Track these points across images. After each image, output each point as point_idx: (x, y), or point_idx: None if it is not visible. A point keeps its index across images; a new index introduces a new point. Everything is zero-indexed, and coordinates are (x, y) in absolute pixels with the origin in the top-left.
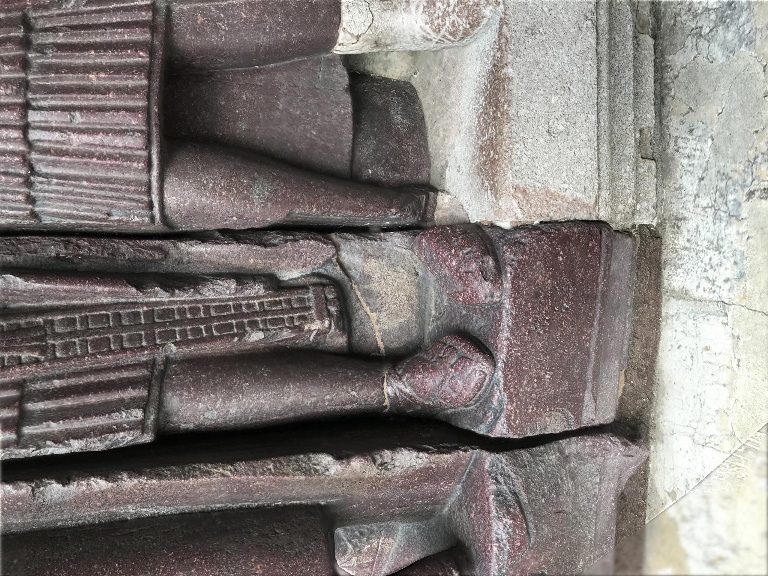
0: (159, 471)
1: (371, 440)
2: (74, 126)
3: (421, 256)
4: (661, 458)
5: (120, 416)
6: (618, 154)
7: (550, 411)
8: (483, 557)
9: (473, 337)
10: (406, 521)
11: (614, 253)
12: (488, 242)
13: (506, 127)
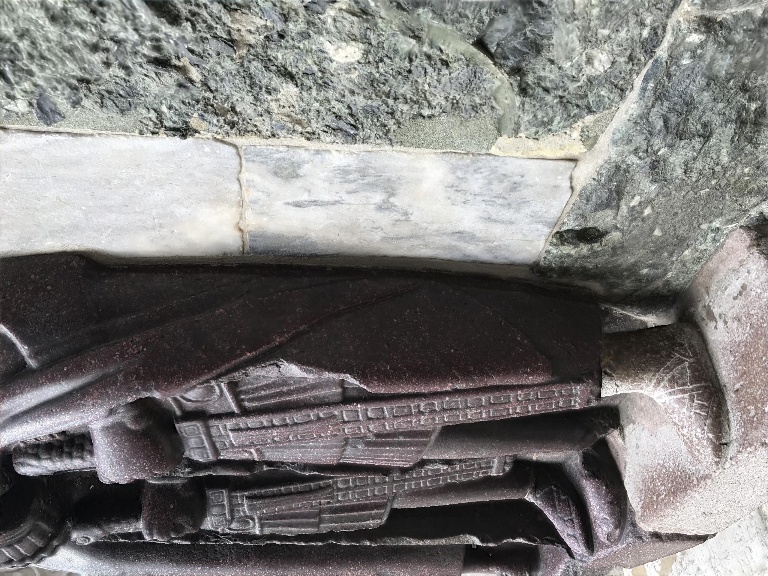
0: (385, 540)
1: (505, 519)
2: (368, 461)
3: None
4: None
5: (369, 521)
6: None
7: None
8: (545, 574)
9: (589, 526)
10: None
11: None
12: (623, 519)
13: (670, 510)
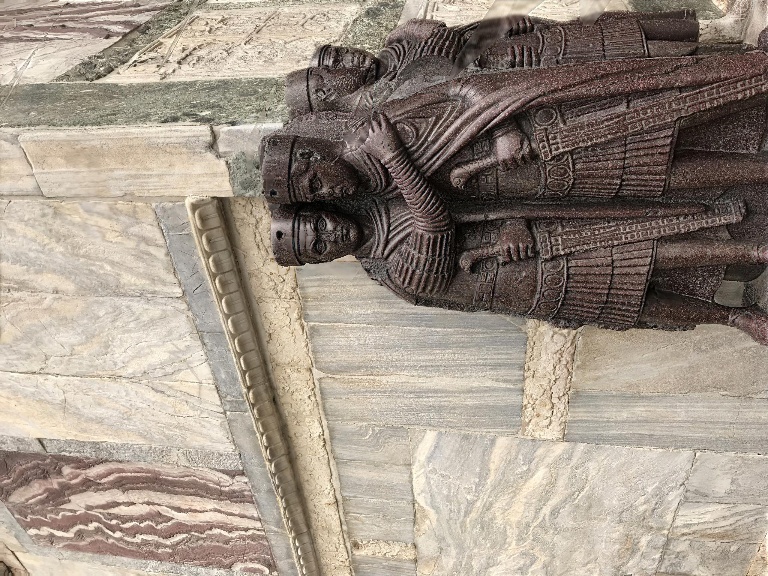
0: None
1: None
2: None
3: (762, 43)
4: None
5: None
6: None
7: None
8: None
9: None
10: None
11: None
12: None
13: None
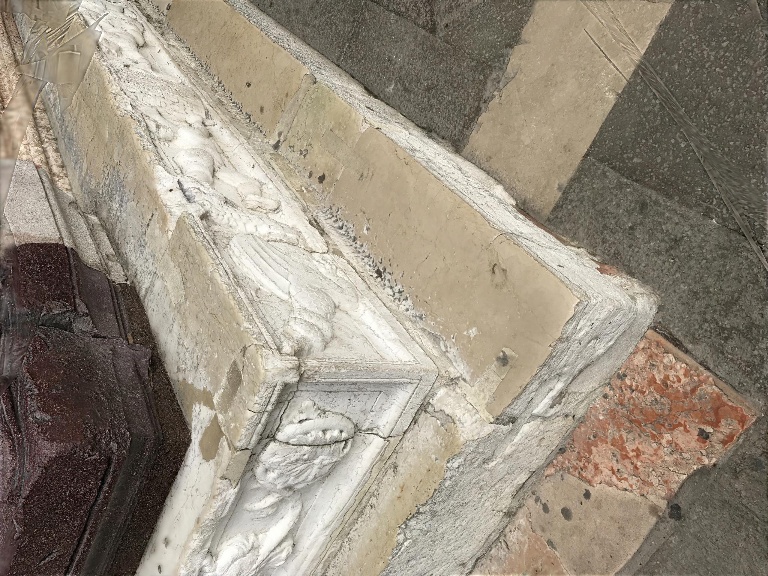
0: None
1: None
2: None
3: None
4: (168, 362)
5: None
6: None
7: (51, 301)
8: None
9: None
10: None
11: (92, 274)
12: None
13: None
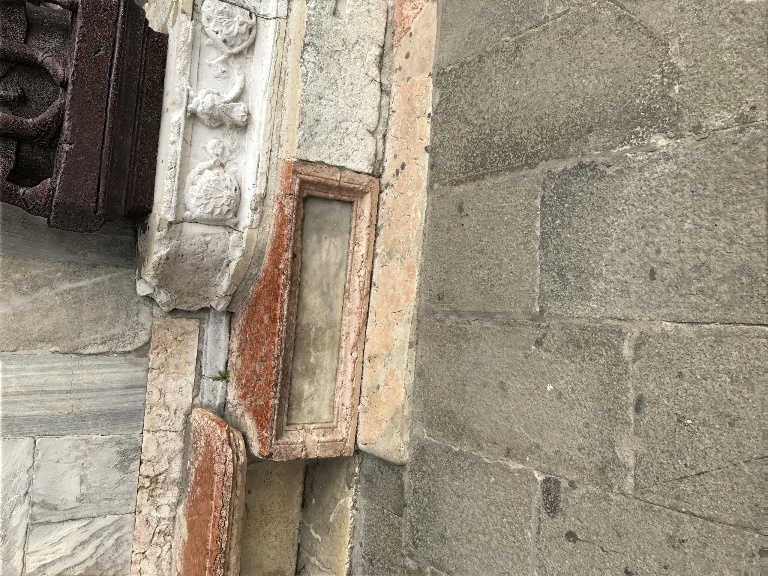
0: None
1: None
2: None
3: None
4: None
5: None
6: None
7: None
8: None
9: None
10: (63, 36)
11: None
12: None
13: None
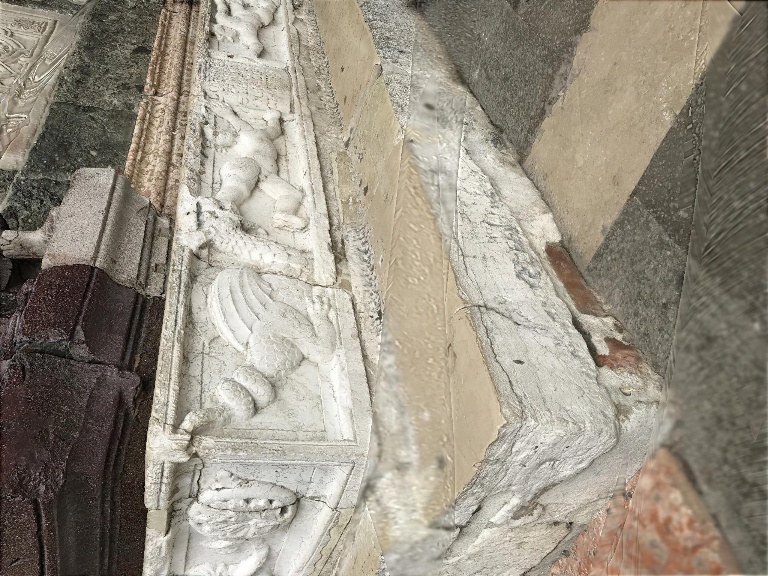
0: None
1: None
2: None
3: None
4: None
5: None
6: (126, 260)
7: (51, 329)
8: None
9: None
10: None
11: (119, 292)
12: None
13: None
